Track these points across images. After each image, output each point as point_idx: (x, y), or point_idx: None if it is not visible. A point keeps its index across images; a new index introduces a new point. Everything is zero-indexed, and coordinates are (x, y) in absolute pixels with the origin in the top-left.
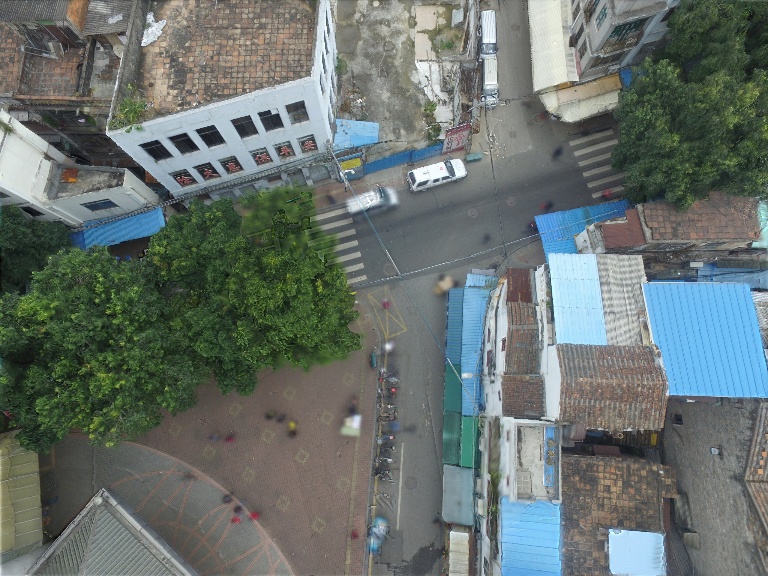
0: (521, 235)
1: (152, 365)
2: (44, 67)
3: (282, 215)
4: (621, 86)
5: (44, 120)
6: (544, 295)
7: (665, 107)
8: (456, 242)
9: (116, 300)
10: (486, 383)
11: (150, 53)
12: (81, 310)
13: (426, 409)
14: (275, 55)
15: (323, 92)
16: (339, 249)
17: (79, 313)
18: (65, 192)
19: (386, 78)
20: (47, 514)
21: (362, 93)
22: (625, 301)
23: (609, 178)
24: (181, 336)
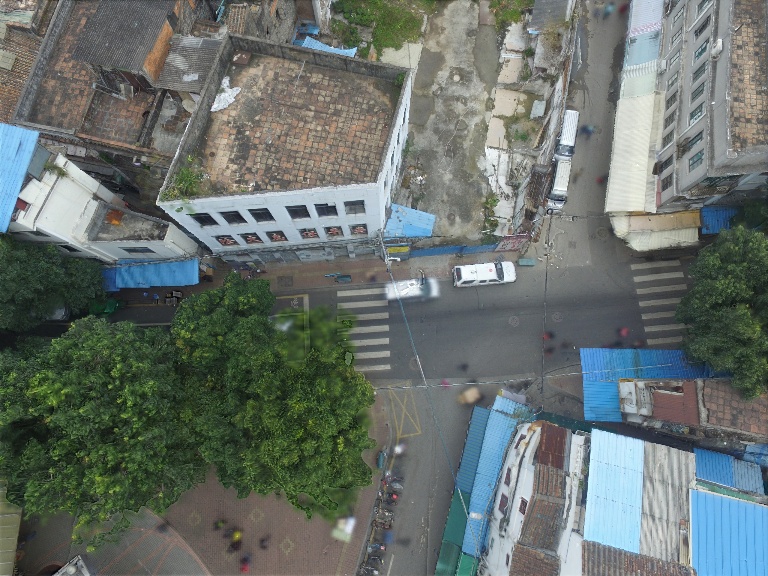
0: (560, 356)
1: (152, 465)
2: (111, 106)
3: (317, 353)
4: (700, 224)
5: (101, 156)
6: (578, 470)
7: (749, 279)
8: (491, 349)
9: (129, 394)
10: (494, 529)
11: (218, 120)
12: (92, 397)
13: (424, 523)
14: (344, 147)
15: (385, 186)
16: (368, 331)
17: (88, 406)
18: (106, 233)
19: (452, 159)
20: (22, 548)
21: (424, 170)
22: (668, 504)
23: (666, 313)
24: (188, 432)
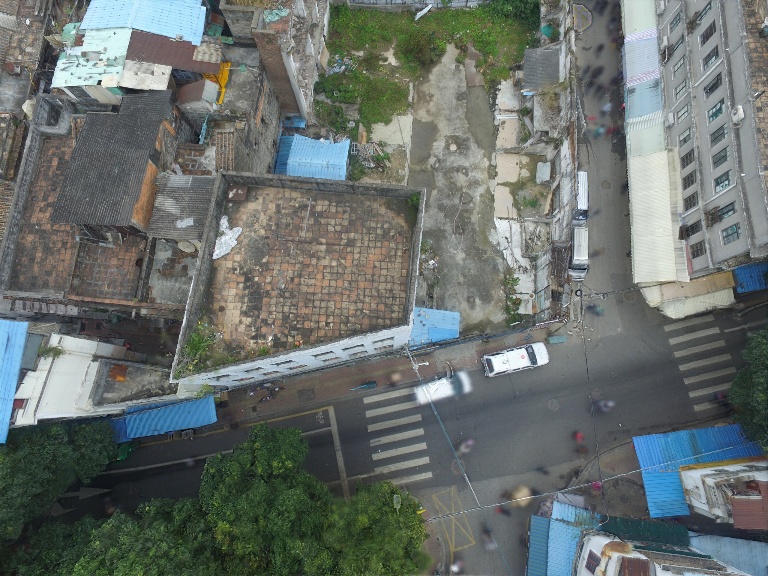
0: (607, 436)
1: None
2: (99, 256)
3: (386, 567)
4: (734, 284)
5: None
6: None
7: None
8: (534, 439)
9: None
10: None
11: (222, 268)
12: None
13: None
14: (364, 281)
15: None
16: (403, 438)
17: None
18: (111, 392)
19: (461, 236)
20: None
21: (434, 252)
22: None
23: (709, 374)
24: None
